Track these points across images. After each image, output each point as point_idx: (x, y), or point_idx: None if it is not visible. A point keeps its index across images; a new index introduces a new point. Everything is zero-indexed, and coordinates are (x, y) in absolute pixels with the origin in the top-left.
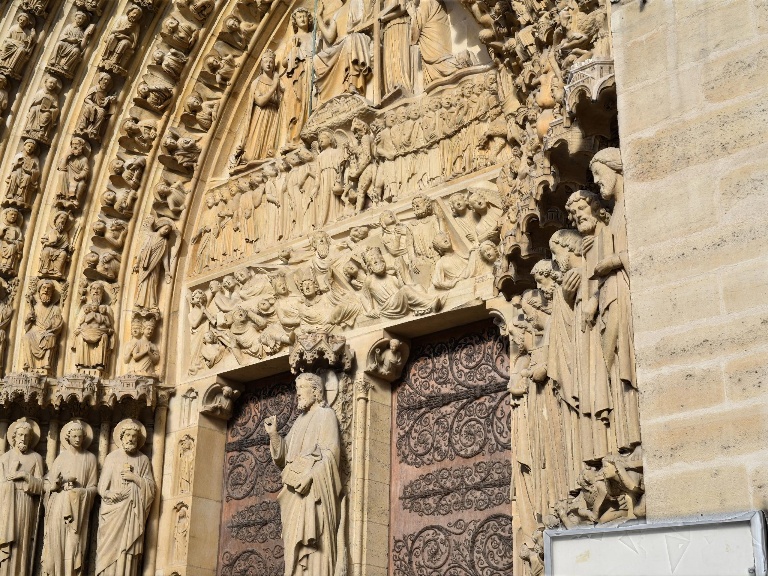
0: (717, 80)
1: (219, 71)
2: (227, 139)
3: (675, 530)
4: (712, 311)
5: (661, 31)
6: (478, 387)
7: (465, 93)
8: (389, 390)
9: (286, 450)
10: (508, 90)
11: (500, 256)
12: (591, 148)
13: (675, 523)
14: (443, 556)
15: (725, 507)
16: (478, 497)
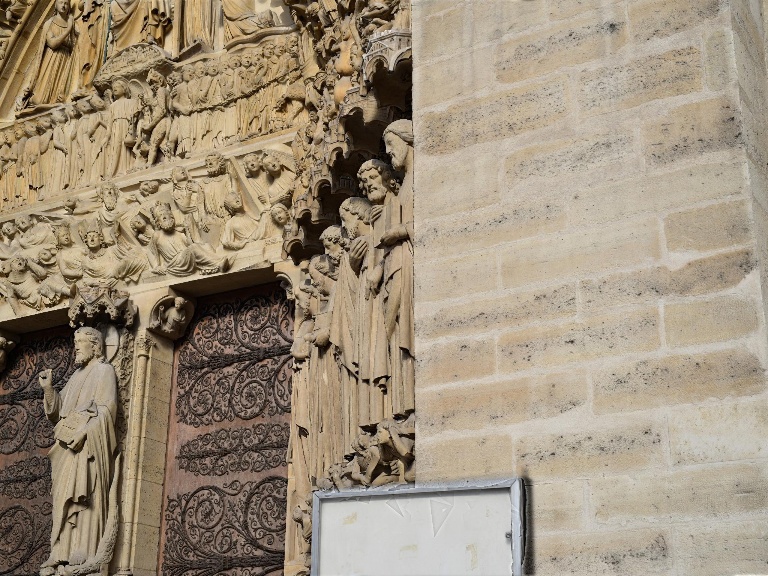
0: (509, 61)
1: (10, 8)
2: (15, 80)
3: (440, 495)
4: (490, 285)
5: (459, 8)
6: (261, 349)
7: (265, 53)
8: (171, 348)
9: (60, 405)
10: (308, 54)
11: (291, 220)
12: (385, 118)
13: (440, 488)
14: (217, 516)
15: (490, 474)
16: (255, 459)
